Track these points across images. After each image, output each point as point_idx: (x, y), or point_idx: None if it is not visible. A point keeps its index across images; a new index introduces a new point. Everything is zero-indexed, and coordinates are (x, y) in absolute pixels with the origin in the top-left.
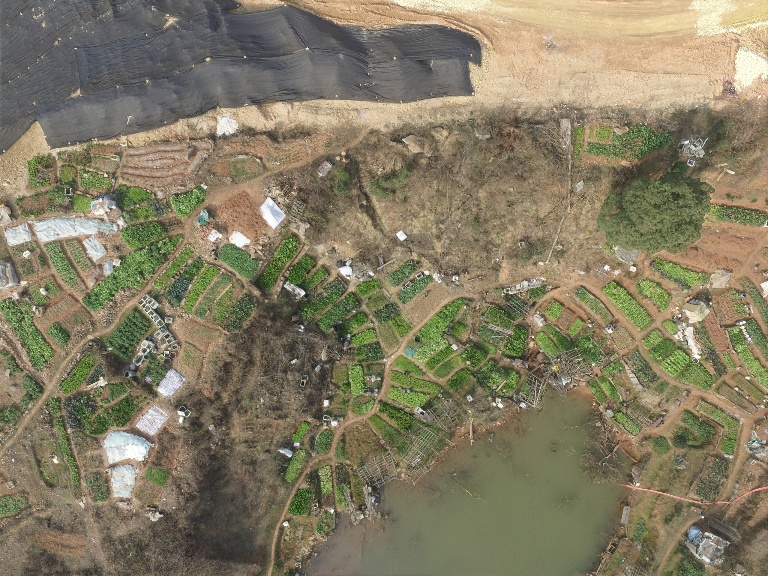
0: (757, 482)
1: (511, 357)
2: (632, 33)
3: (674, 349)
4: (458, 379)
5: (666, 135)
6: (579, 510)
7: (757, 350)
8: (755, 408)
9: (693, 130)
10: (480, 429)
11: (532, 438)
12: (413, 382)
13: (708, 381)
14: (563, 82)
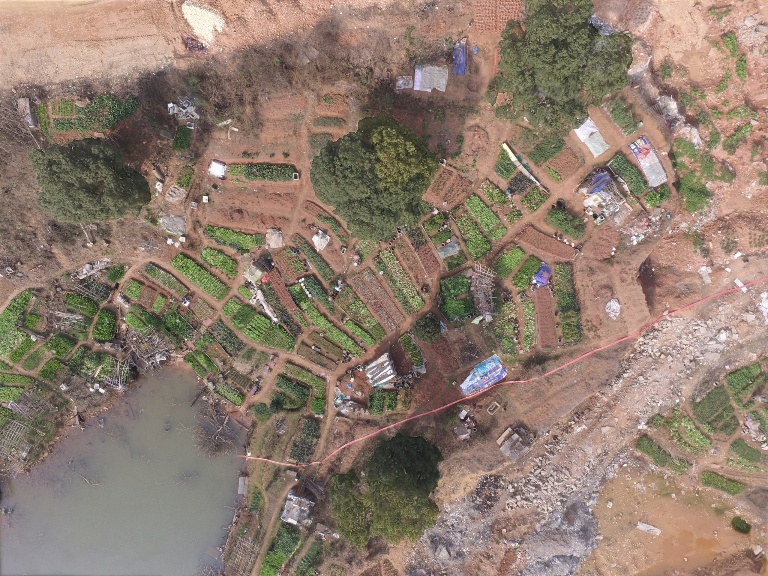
0: (344, 439)
1: (103, 341)
2: (75, 3)
3: (255, 314)
4: (48, 369)
5: (131, 101)
6: (201, 485)
7: (321, 306)
8: (335, 364)
9: (176, 92)
10: (88, 416)
11: (145, 419)
12: (2, 377)
13: (290, 343)
14: (16, 62)
